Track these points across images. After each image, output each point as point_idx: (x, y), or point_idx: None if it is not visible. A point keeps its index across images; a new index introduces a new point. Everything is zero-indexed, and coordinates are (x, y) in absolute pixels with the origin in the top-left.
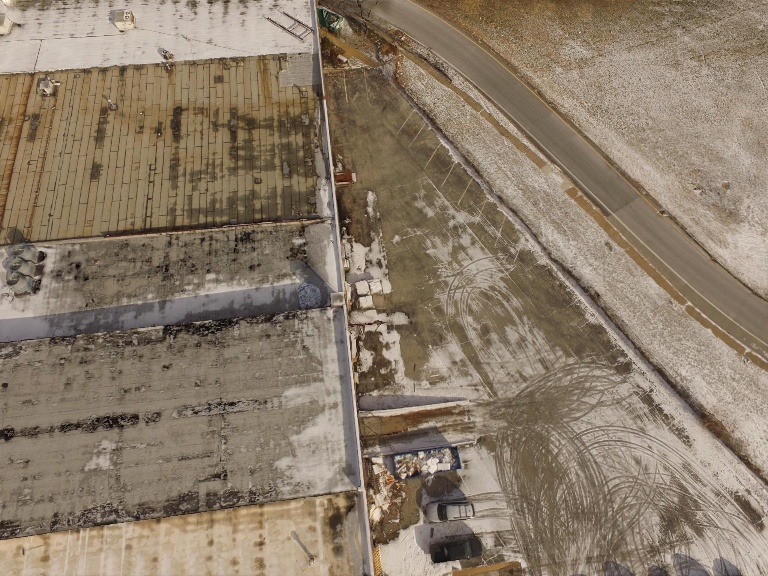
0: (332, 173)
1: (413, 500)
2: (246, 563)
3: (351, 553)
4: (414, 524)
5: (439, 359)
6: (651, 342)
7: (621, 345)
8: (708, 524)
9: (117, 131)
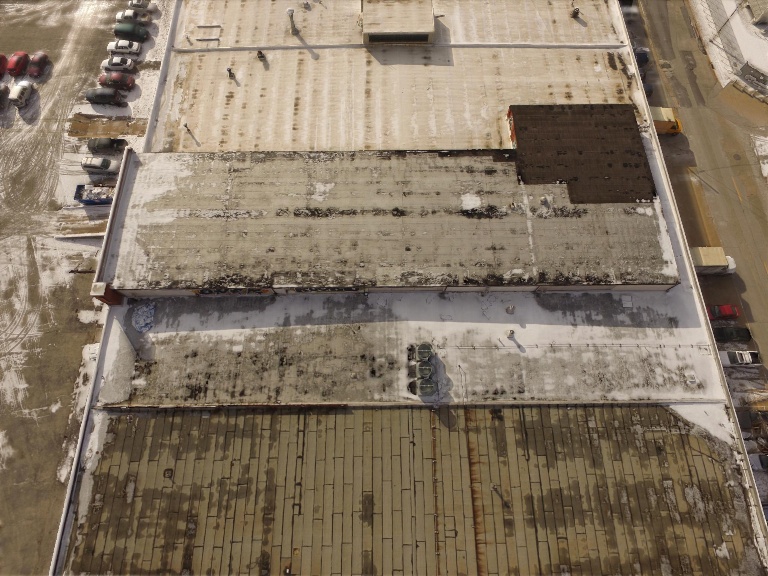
0: (72, 474)
1: None
2: (234, 133)
3: (163, 132)
4: None
5: (65, 274)
6: None
7: None
8: None
9: None
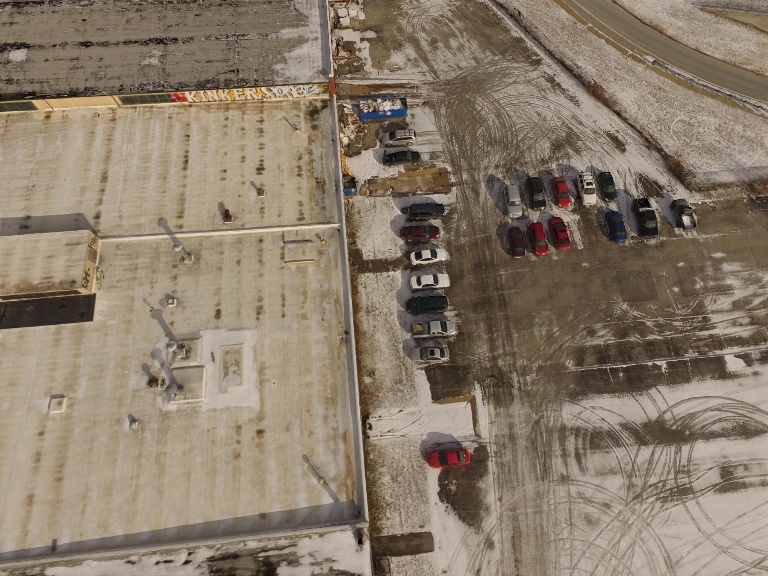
0: None
1: (373, 135)
2: (251, 130)
3: (324, 129)
4: (372, 148)
5: (398, 57)
6: (558, 46)
7: (535, 49)
8: (585, 148)
9: None
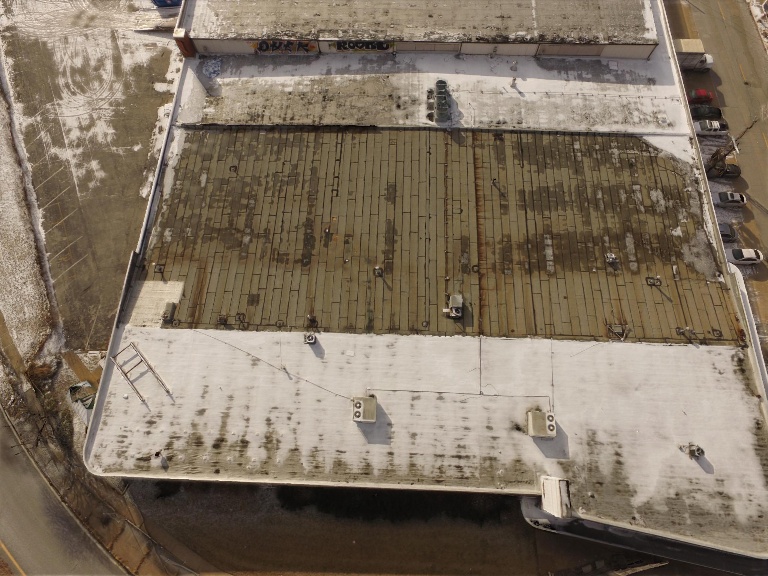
0: (158, 165)
1: None
2: None
3: None
4: None
5: (142, 57)
6: None
7: (1, 42)
8: None
9: (373, 239)
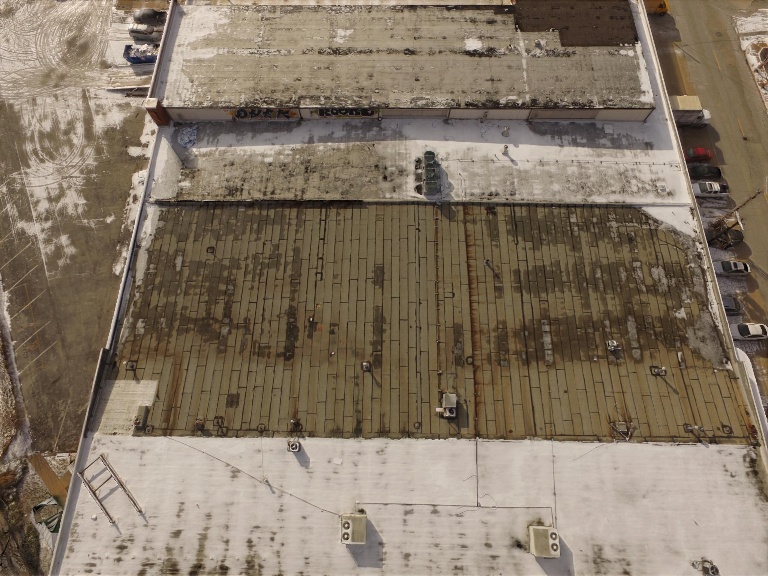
0: (130, 247)
1: None
2: None
3: None
4: None
5: (115, 118)
6: None
7: None
8: None
9: (360, 329)
